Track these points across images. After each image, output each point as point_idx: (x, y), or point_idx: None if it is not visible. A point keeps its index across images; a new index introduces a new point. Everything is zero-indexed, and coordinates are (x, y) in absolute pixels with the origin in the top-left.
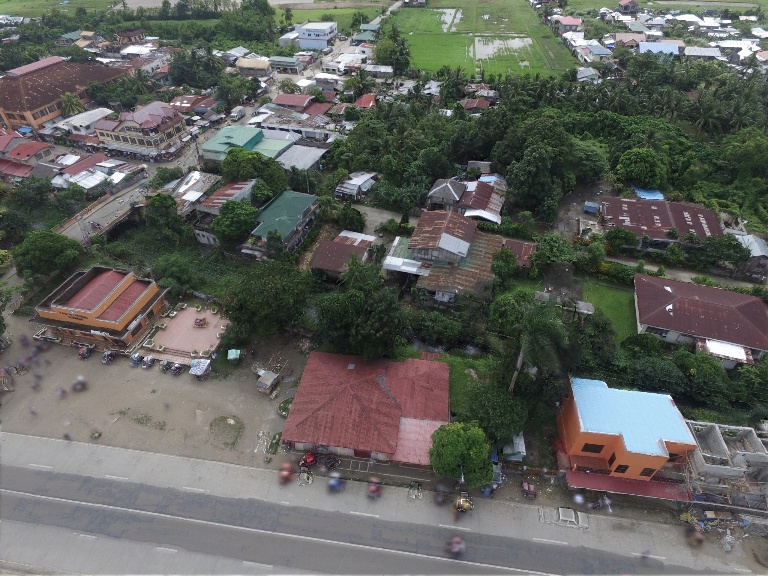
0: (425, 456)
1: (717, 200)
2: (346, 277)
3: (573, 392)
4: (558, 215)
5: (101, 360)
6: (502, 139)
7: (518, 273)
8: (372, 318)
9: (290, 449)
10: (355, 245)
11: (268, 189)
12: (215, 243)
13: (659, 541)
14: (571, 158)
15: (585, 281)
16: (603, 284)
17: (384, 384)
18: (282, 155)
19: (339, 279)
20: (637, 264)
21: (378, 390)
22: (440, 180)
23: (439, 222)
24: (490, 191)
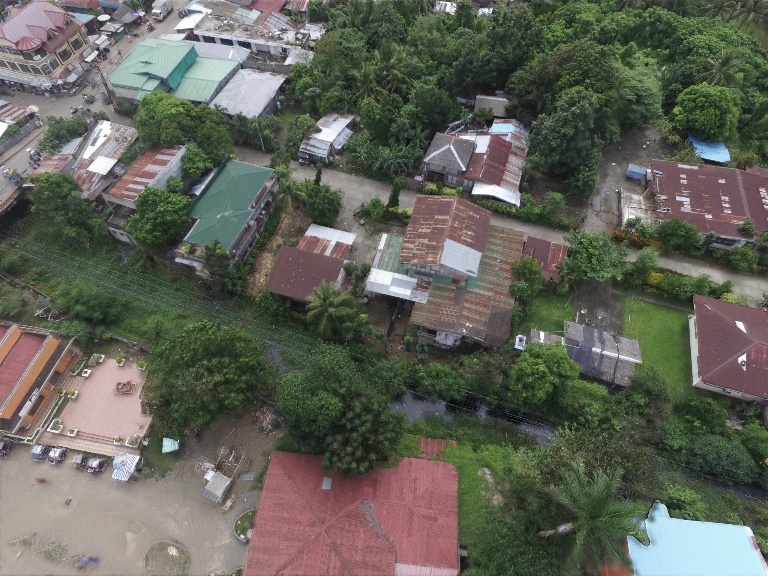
0: None
1: None
2: (317, 308)
3: (627, 537)
4: None
5: None
6: (523, 63)
7: (542, 286)
8: (353, 441)
9: None
10: (328, 255)
11: (205, 158)
12: (139, 244)
13: None
14: (618, 102)
15: (627, 297)
16: (650, 301)
17: (372, 514)
18: (224, 89)
19: (308, 306)
20: (693, 267)
21: (364, 527)
22: (440, 136)
23: (441, 218)
24: (506, 151)
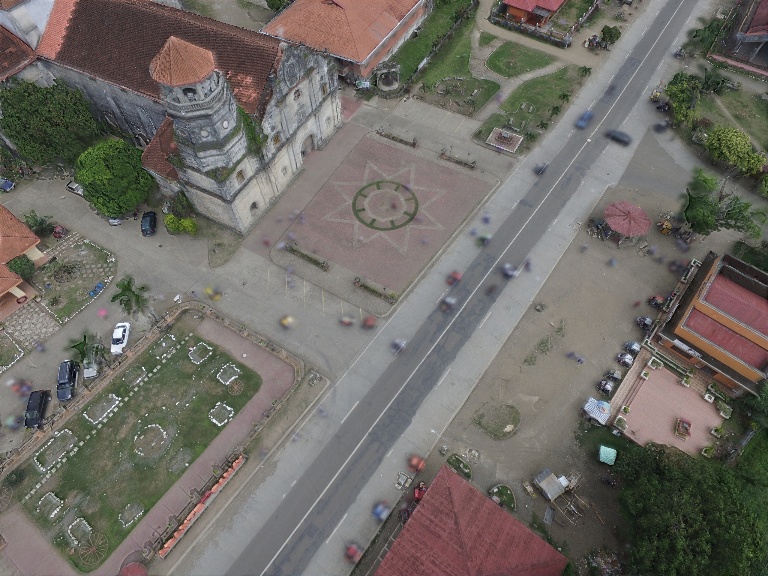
0: None
1: None
2: None
3: None
4: None
5: None
6: None
7: None
8: None
9: None
10: None
11: None
12: None
13: None
14: None
15: None
16: None
17: None
18: None
19: None
20: None
21: None
22: None
23: None
24: None
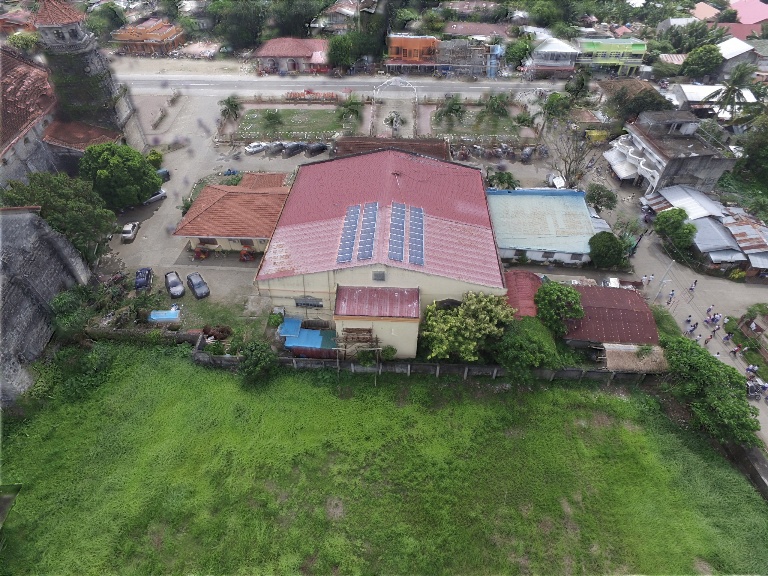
0: (320, 61)
1: (507, 1)
2: None
3: None
4: (415, 15)
5: (150, 59)
6: None
7: None
8: (292, 8)
9: (256, 71)
10: None
11: None
12: (203, 27)
13: (420, 79)
14: None
15: None
16: None
17: (301, 42)
18: None
19: None
20: None
21: (298, 42)
22: None
23: (337, 5)
24: (374, 3)
